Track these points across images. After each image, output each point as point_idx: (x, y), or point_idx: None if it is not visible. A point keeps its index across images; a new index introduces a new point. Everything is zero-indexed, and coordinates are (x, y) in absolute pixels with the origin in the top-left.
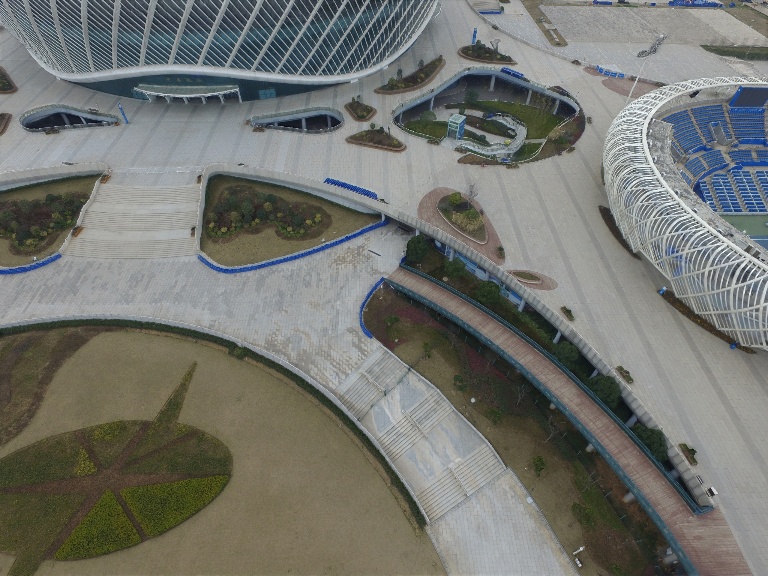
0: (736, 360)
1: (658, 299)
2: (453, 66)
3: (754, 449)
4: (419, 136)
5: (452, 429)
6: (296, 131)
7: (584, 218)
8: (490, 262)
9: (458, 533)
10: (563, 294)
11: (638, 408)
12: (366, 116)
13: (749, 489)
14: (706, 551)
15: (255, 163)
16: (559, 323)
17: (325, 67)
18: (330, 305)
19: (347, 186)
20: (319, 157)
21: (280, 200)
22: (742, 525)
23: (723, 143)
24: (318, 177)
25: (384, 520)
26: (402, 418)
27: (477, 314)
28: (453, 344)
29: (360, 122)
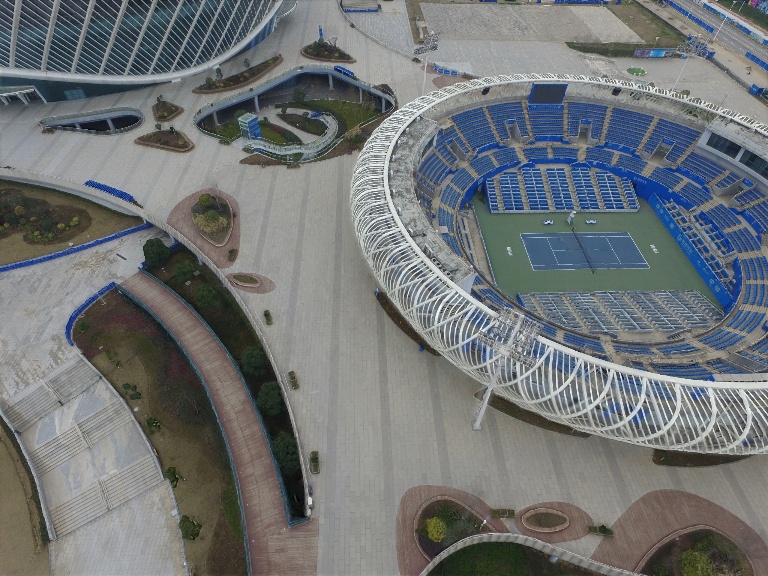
0: (419, 363)
1: (372, 301)
2: (288, 65)
3: (388, 455)
4: (212, 136)
5: (122, 439)
6: (86, 132)
7: (340, 218)
8: (213, 265)
9: (82, 549)
10: (275, 297)
11: (290, 415)
12: (167, 116)
13: (361, 498)
14: (280, 565)
15: (26, 165)
16: (255, 327)
17: (132, 66)
18: (46, 312)
19: (105, 188)
20: (97, 159)
21: (43, 203)
22: (333, 536)
23: (519, 140)
24: (84, 179)
25: (7, 537)
26: (69, 429)
27: (190, 319)
28: (157, 350)
29: (160, 122)
